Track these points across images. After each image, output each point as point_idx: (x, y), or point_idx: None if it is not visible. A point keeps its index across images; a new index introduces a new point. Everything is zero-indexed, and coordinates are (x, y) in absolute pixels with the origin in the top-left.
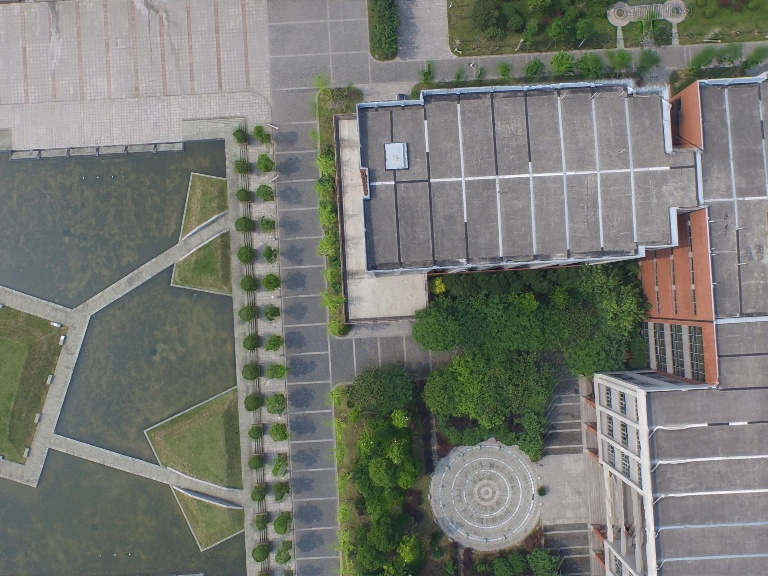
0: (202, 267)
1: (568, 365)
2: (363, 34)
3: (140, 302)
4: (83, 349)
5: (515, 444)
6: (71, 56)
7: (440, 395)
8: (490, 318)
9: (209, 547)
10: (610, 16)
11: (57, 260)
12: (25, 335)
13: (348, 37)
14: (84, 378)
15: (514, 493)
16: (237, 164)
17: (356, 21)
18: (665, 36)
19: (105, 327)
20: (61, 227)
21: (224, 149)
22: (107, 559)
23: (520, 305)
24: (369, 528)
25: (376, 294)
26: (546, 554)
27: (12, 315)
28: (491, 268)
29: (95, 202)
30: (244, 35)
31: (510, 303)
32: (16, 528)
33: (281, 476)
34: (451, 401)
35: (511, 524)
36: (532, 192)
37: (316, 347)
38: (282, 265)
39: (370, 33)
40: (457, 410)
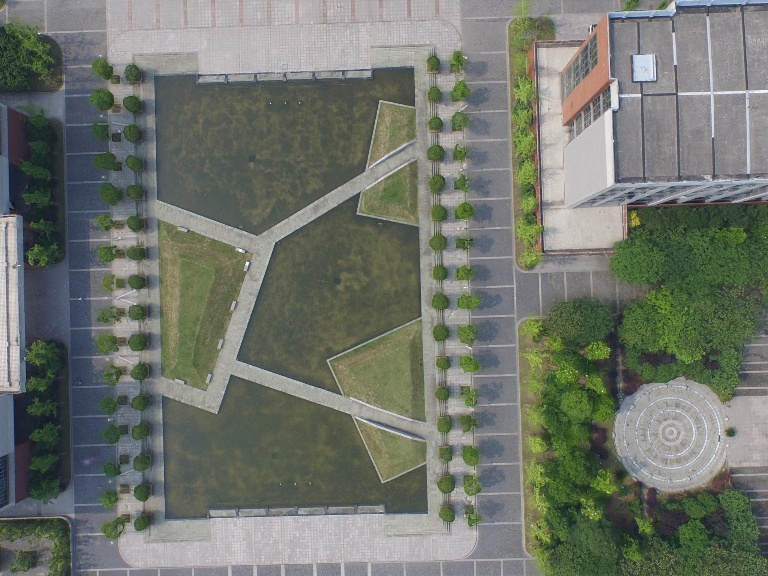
0: (390, 196)
1: (759, 305)
2: None
3: (325, 230)
4: (267, 276)
5: (703, 384)
6: None
7: (642, 327)
8: (696, 250)
9: (390, 479)
10: None
11: (242, 186)
12: (211, 260)
13: None
14: (267, 305)
15: (700, 434)
16: (433, 90)
17: None
18: None
19: (289, 255)
20: (246, 153)
21: (413, 77)
22: (287, 488)
23: (724, 238)
24: (557, 463)
25: (572, 225)
26: (740, 494)
27: (197, 240)
28: (713, 194)
29: (281, 128)
30: None
31: (711, 237)
32: (196, 454)
33: (463, 410)
34: (653, 334)
35: (696, 465)
36: None
37: (501, 280)
38: (468, 197)
39: None
40: (655, 344)
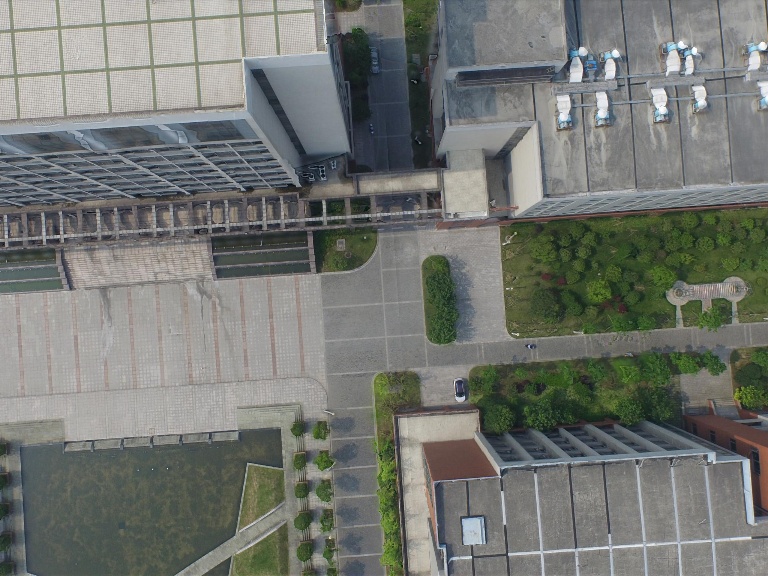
0: (260, 562)
1: None
2: (419, 316)
3: None
4: None
5: None
6: (123, 344)
7: None
8: None
9: None
10: (669, 296)
11: (112, 553)
12: None
13: (404, 320)
14: None
15: None
16: (296, 464)
17: (411, 303)
18: (725, 315)
19: None
20: (116, 520)
21: (280, 438)
22: None
23: None
24: None
25: None
26: None
27: None
28: None
29: (150, 493)
30: (298, 319)
31: None
32: None
33: None
34: None
35: None
36: (612, 565)
37: None
38: (340, 554)
39: (426, 316)
40: None
